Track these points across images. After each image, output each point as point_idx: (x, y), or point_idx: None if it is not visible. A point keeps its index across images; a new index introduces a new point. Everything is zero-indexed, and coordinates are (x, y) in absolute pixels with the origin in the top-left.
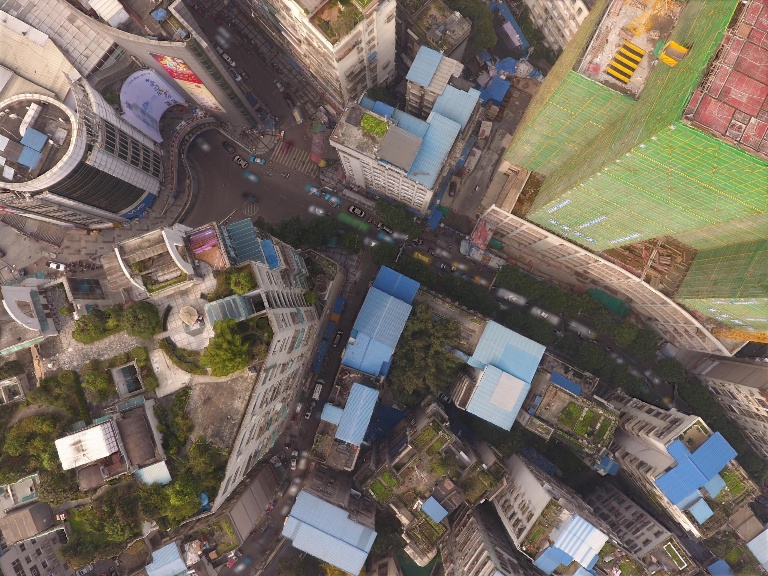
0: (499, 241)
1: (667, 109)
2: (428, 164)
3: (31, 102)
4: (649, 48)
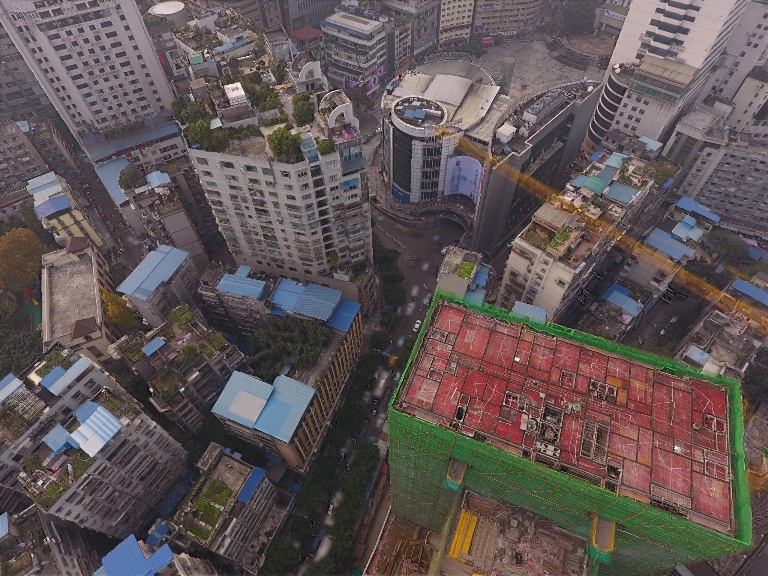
0: None
1: None
2: None
3: (443, 114)
4: None
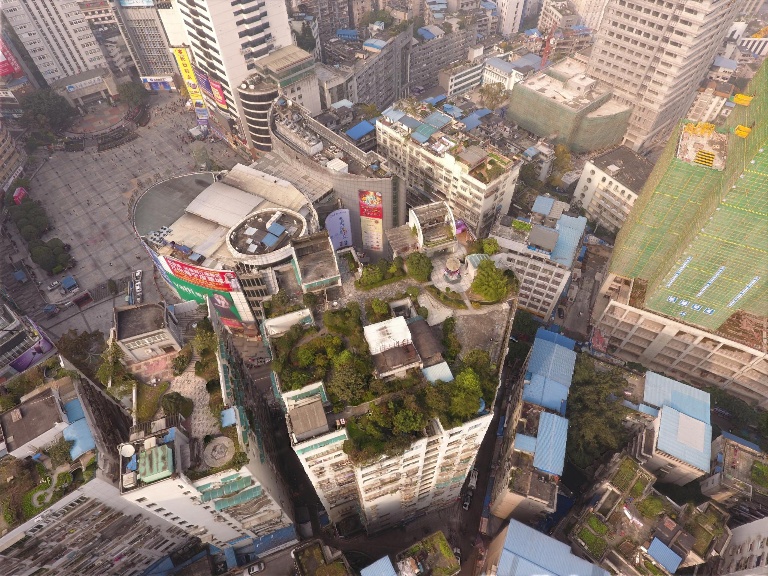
0: (611, 355)
1: (761, 137)
2: (564, 253)
3: None
4: (716, 152)
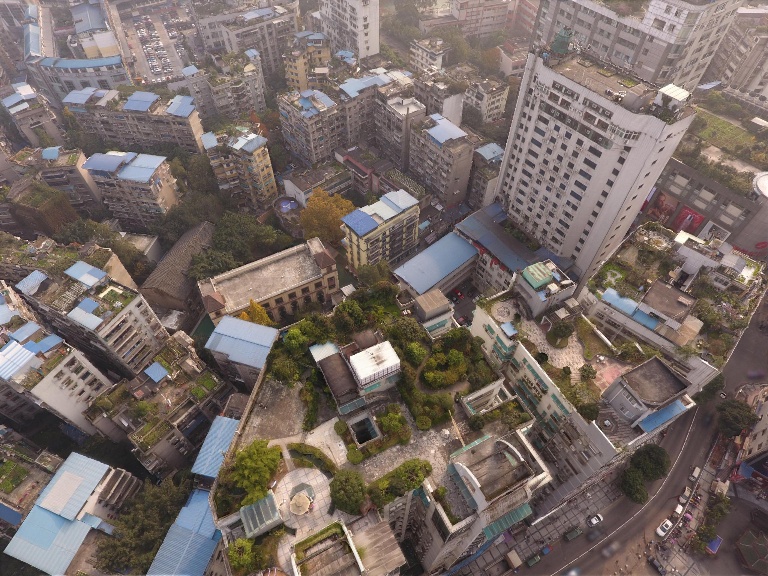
0: None
1: None
2: None
3: None
4: None
